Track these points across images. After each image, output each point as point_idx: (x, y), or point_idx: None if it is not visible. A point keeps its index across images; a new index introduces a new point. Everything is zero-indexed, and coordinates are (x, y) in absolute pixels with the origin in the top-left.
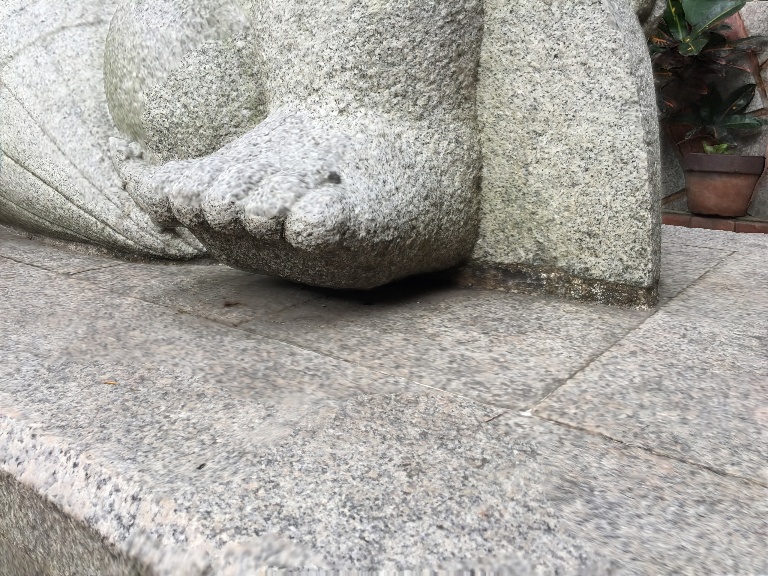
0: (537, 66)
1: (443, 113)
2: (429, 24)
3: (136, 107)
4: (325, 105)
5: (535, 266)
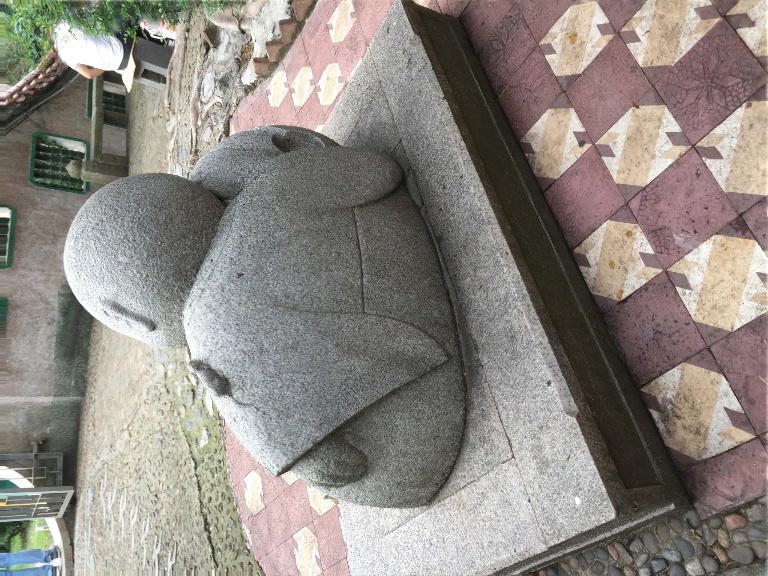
0: None
1: None
2: None
3: None
4: None
5: None
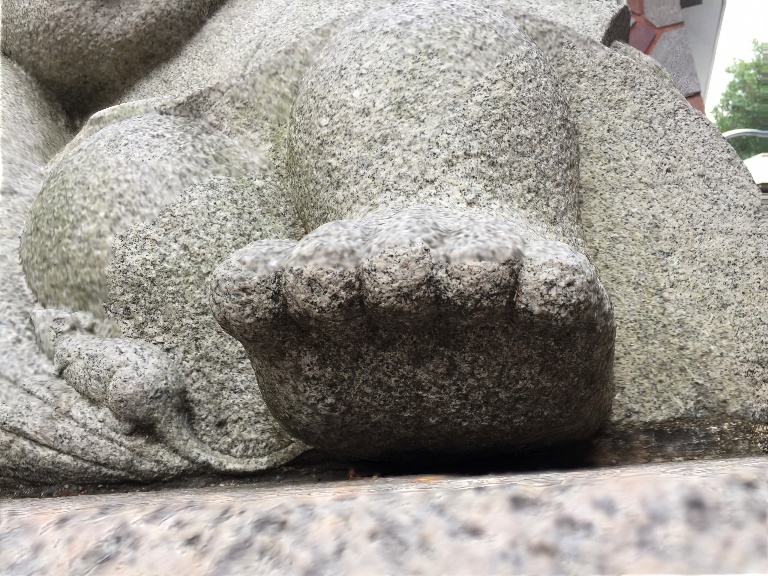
0: (649, 182)
1: (570, 223)
2: (550, 121)
3: (99, 256)
4: (446, 197)
5: (698, 419)
